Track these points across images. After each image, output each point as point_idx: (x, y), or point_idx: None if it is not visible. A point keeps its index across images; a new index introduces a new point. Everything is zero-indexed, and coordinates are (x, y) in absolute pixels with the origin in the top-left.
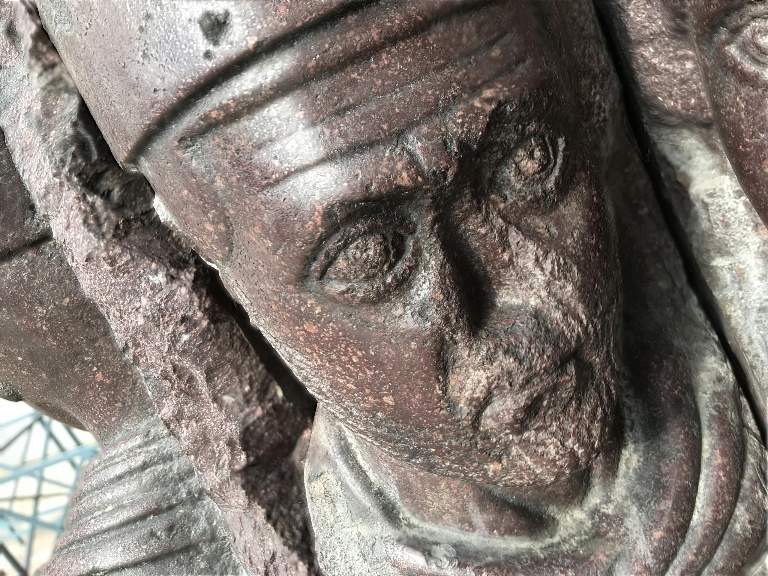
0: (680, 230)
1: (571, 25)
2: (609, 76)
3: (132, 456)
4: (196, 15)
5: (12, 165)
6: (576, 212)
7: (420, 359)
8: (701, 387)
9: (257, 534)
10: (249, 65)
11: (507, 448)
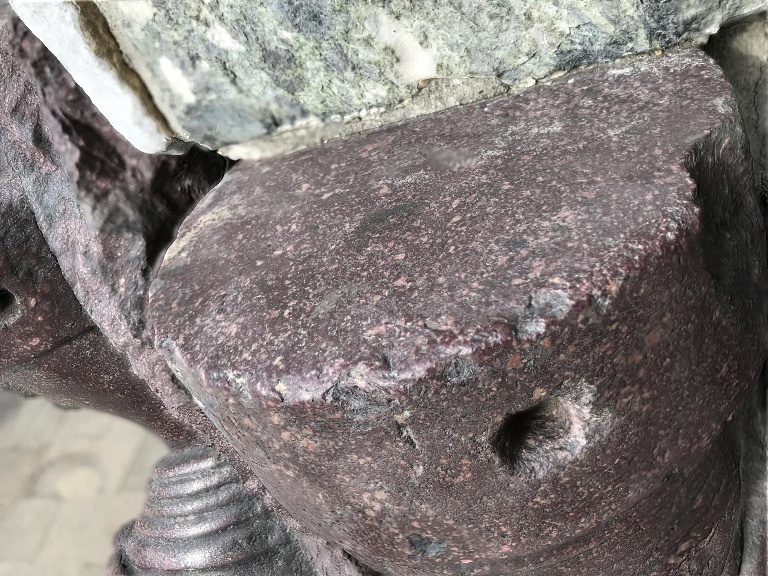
0: (766, 367)
1: None
2: None
3: (206, 476)
4: (406, 535)
5: None
6: (716, 542)
7: None
8: (749, 512)
9: (334, 561)
10: None
11: None
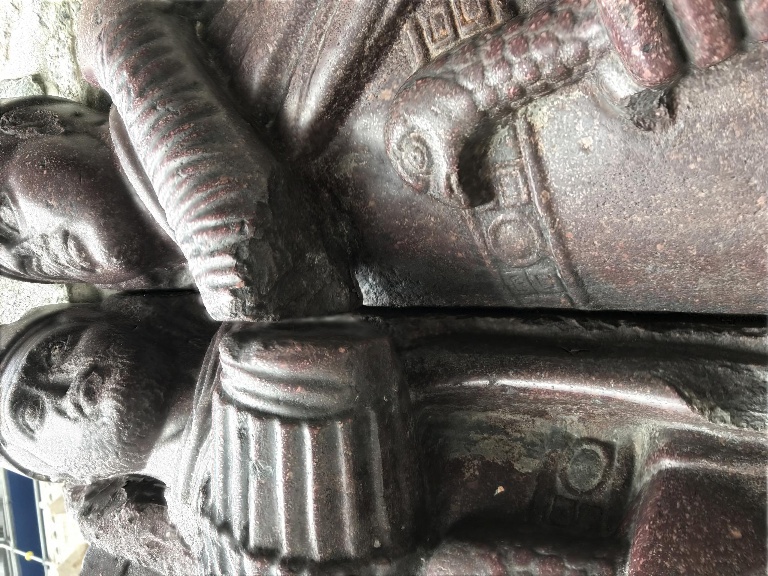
0: None
1: None
2: (132, 299)
3: None
4: None
5: (104, 551)
6: None
7: (57, 419)
8: None
9: None
10: None
11: (100, 411)
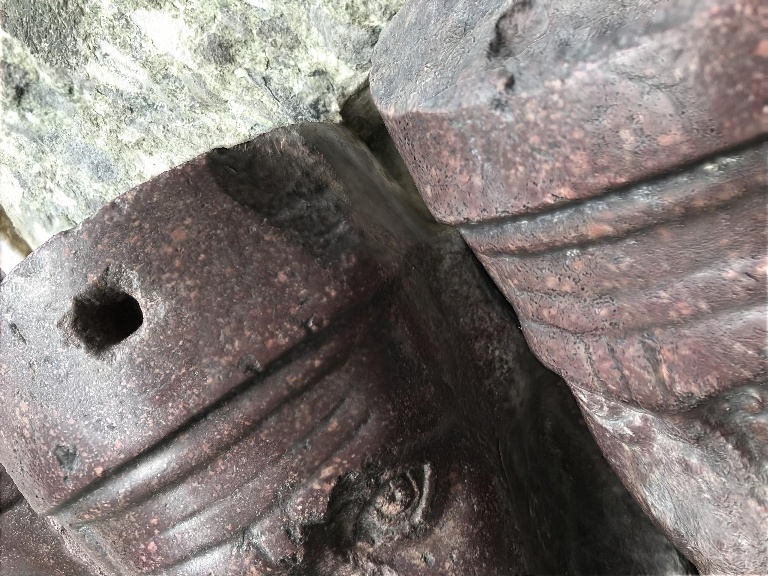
0: None
1: (454, 298)
2: (505, 330)
3: None
4: (52, 449)
5: None
6: (454, 531)
7: None
8: None
9: None
10: (104, 483)
11: None
